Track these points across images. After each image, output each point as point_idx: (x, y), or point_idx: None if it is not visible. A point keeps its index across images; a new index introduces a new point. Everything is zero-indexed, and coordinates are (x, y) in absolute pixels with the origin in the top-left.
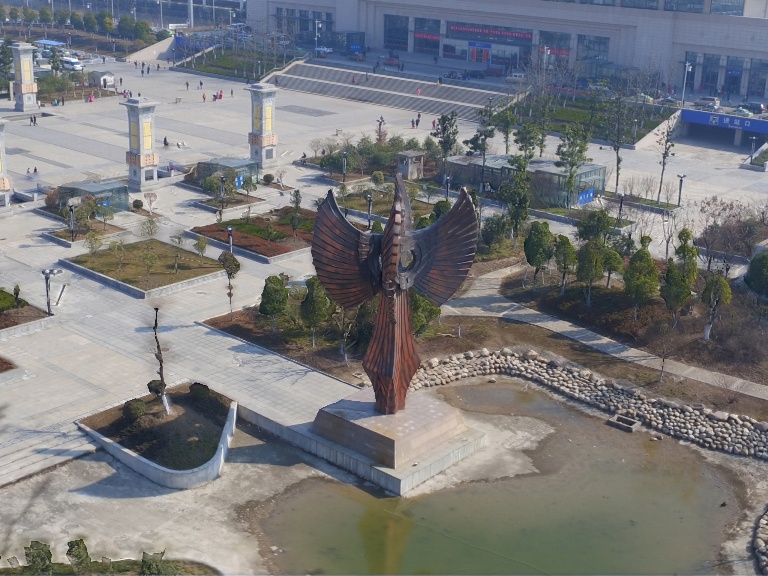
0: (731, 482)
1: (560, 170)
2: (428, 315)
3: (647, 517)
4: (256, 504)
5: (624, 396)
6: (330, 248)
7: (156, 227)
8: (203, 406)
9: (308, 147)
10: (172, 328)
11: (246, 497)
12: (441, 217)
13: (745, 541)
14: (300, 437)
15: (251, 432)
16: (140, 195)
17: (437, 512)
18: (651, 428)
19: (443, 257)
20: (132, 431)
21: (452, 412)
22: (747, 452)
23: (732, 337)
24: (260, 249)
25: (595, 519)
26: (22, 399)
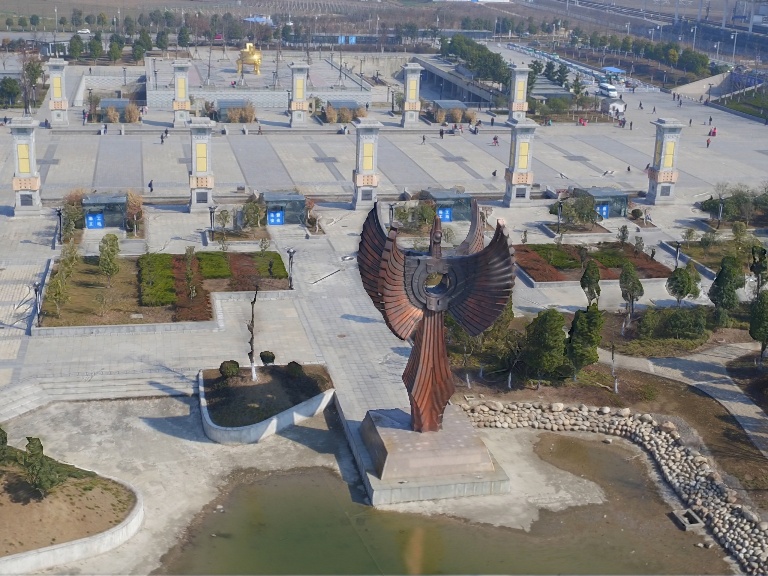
0: None
1: None
2: (579, 360)
3: None
4: (254, 471)
5: (713, 493)
6: (370, 256)
7: (452, 236)
8: (294, 383)
9: (713, 190)
10: (372, 321)
11: (254, 464)
12: None
13: None
14: None
15: (330, 418)
16: (505, 210)
17: (386, 529)
18: (711, 534)
19: (482, 287)
20: (220, 386)
21: (477, 447)
22: None
23: None
24: (534, 273)
25: None
26: (192, 344)
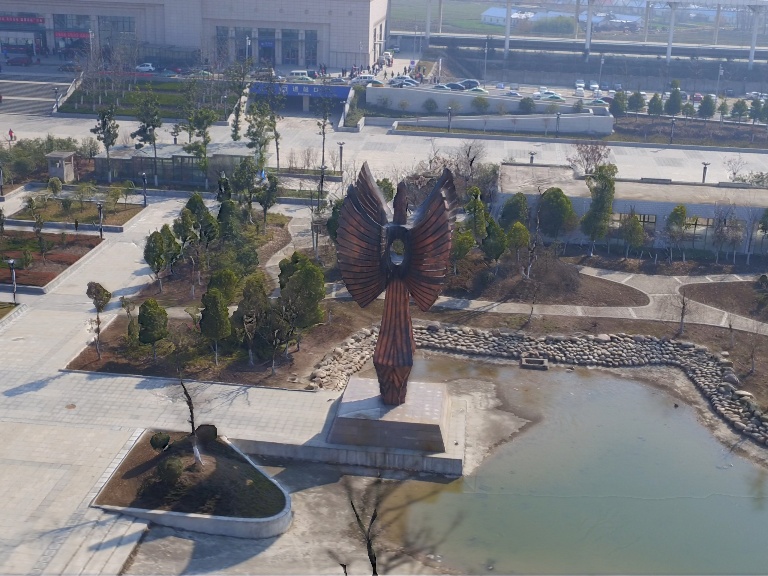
0: (658, 388)
1: (252, 151)
2: None
3: (645, 431)
4: None
5: (516, 341)
6: (356, 248)
7: None
8: (214, 448)
9: None
10: (44, 383)
11: (343, 522)
12: (196, 213)
13: (725, 427)
14: (323, 451)
15: (258, 462)
16: None
17: (505, 479)
18: (557, 362)
19: None
20: (180, 494)
21: (444, 388)
22: (644, 362)
23: (549, 273)
24: (24, 280)
25: (615, 445)
26: None
